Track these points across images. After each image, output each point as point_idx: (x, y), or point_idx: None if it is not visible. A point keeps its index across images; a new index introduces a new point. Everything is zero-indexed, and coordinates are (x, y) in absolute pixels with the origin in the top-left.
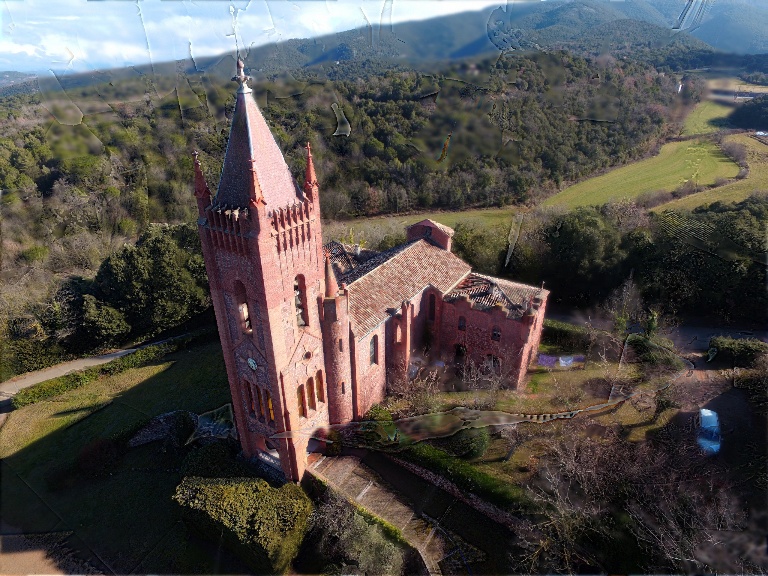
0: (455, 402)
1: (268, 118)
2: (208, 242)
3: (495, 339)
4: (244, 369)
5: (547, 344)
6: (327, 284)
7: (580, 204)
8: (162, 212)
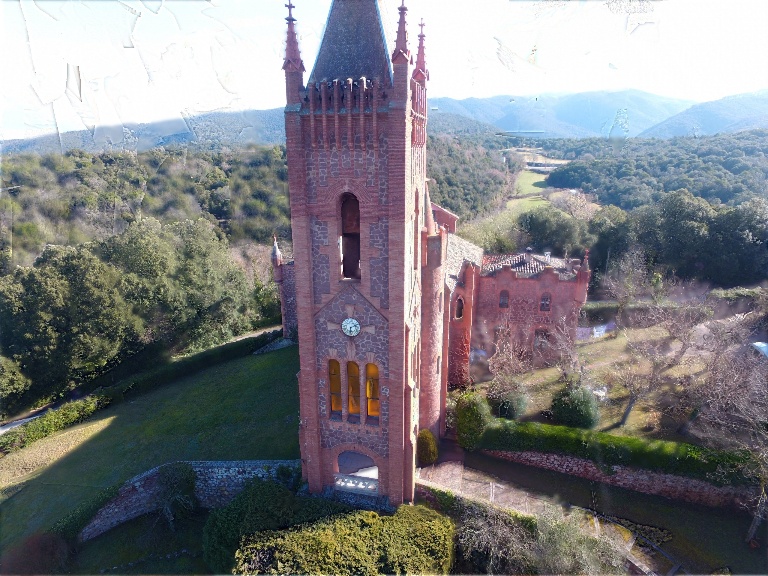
0: None
1: (168, 149)
2: (301, 139)
3: (544, 309)
4: (332, 341)
5: None
6: (426, 218)
7: (533, 204)
8: (30, 258)
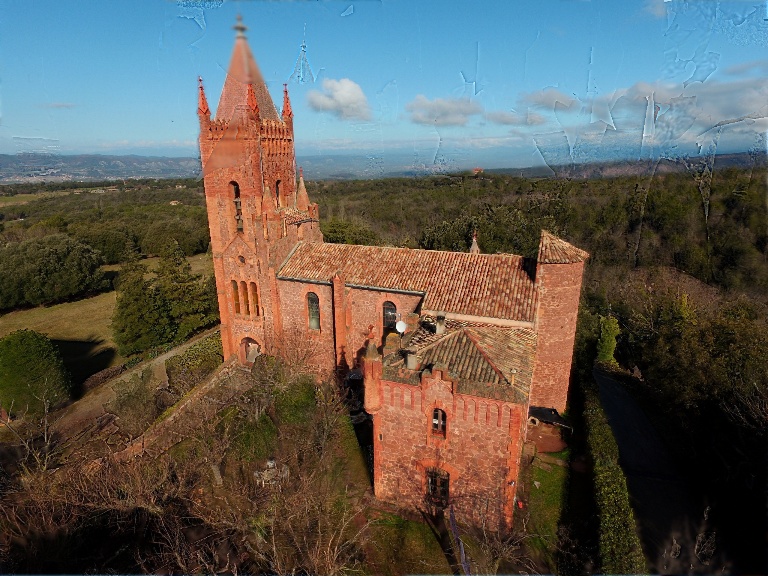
0: None
1: None
2: None
3: None
4: None
5: (559, 557)
6: None
7: None
8: (586, 236)
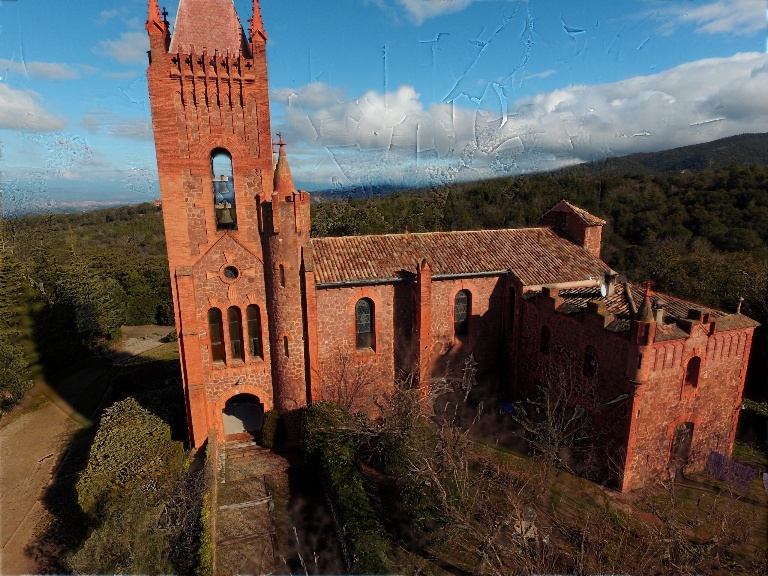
0: (483, 461)
1: (503, 162)
2: None
3: (590, 375)
4: None
5: None
6: (276, 183)
7: None
8: None
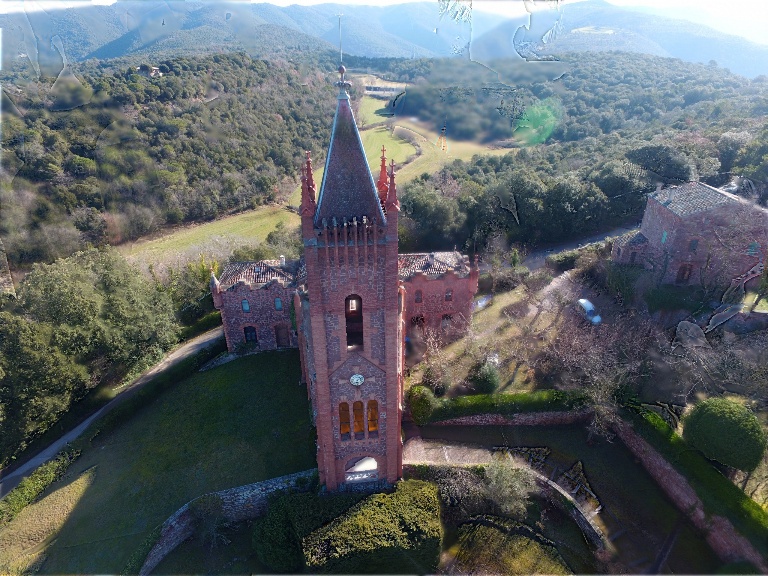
0: None
1: None
2: (318, 263)
3: (448, 300)
4: (342, 391)
5: None
6: None
7: (410, 184)
8: None
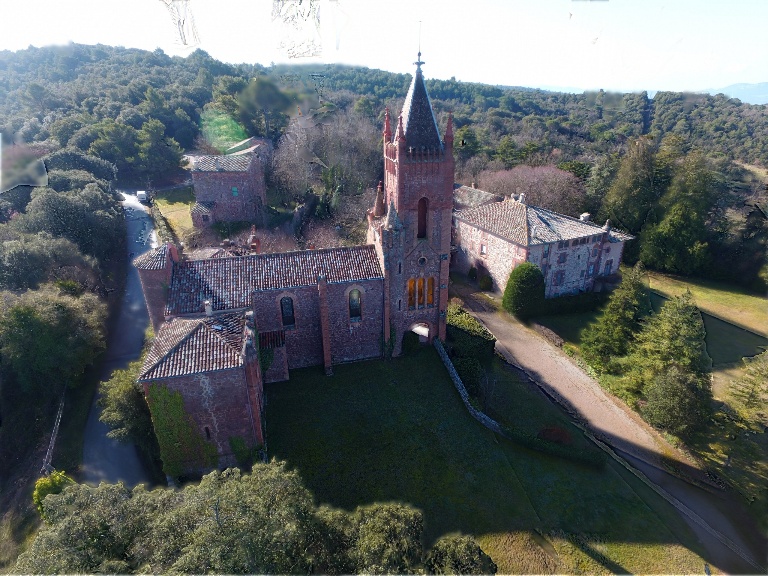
0: None
1: None
2: None
3: None
4: None
5: None
6: None
7: None
8: None
